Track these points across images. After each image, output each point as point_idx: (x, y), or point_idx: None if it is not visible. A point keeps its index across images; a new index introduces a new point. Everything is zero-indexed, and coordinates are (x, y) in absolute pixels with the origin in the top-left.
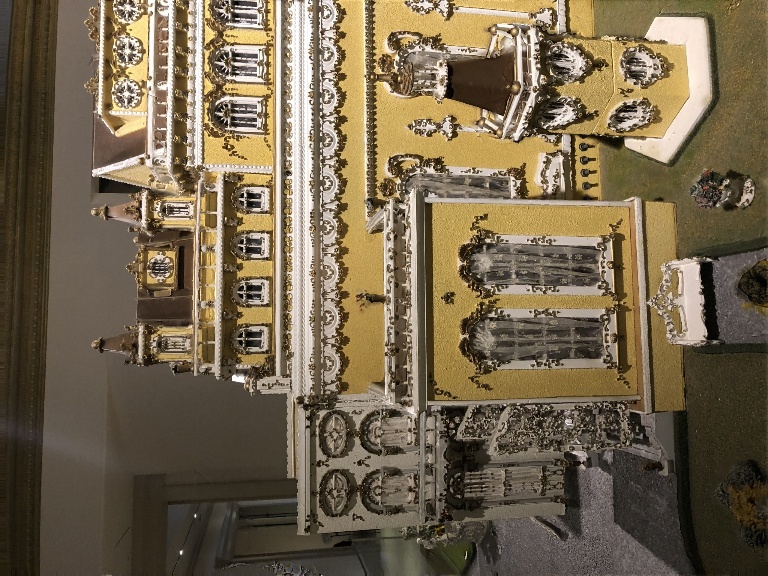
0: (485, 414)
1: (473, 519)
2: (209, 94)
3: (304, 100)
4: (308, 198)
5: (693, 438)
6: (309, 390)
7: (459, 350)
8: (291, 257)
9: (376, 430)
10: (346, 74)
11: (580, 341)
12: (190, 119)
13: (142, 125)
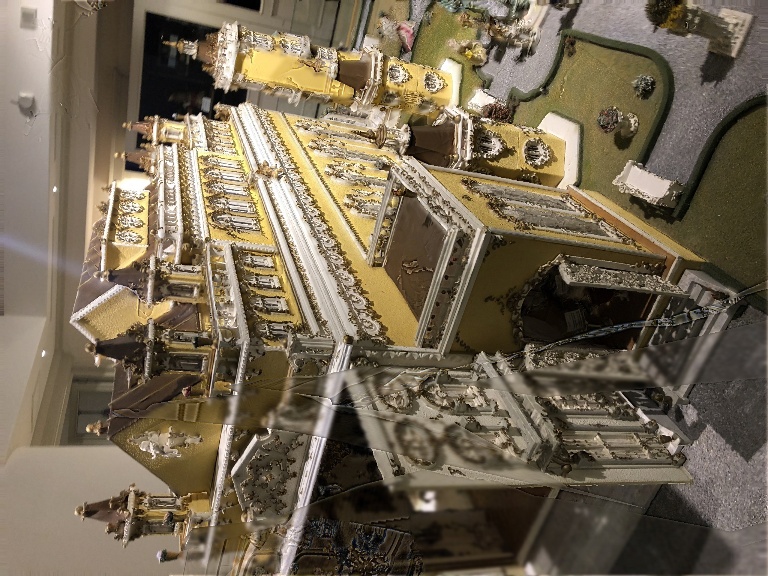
0: (544, 356)
1: (595, 479)
2: (211, 213)
3: (293, 209)
4: (312, 241)
5: (730, 266)
6: (355, 333)
7: (495, 217)
8: (305, 273)
9: (438, 393)
10: (321, 207)
11: None
12: (196, 221)
13: (141, 254)
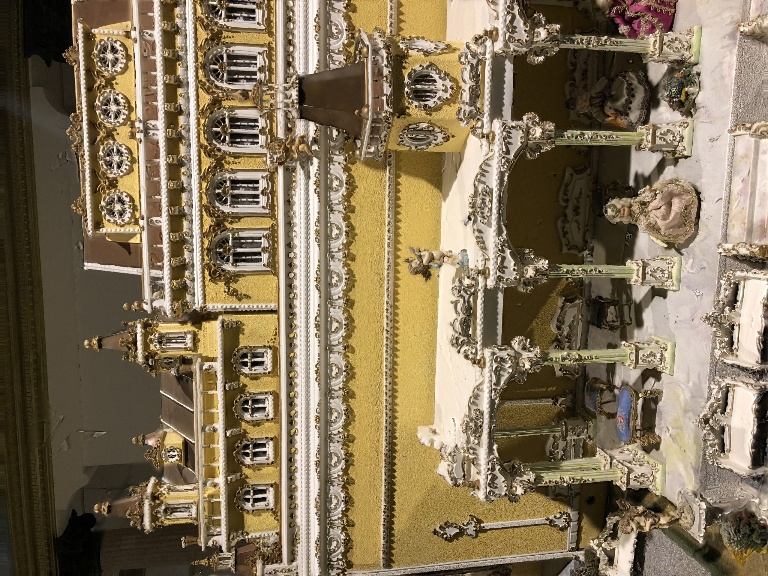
0: None
1: None
2: None
3: None
4: None
5: None
6: None
7: None
8: None
9: None
10: None
11: None
12: None
13: None
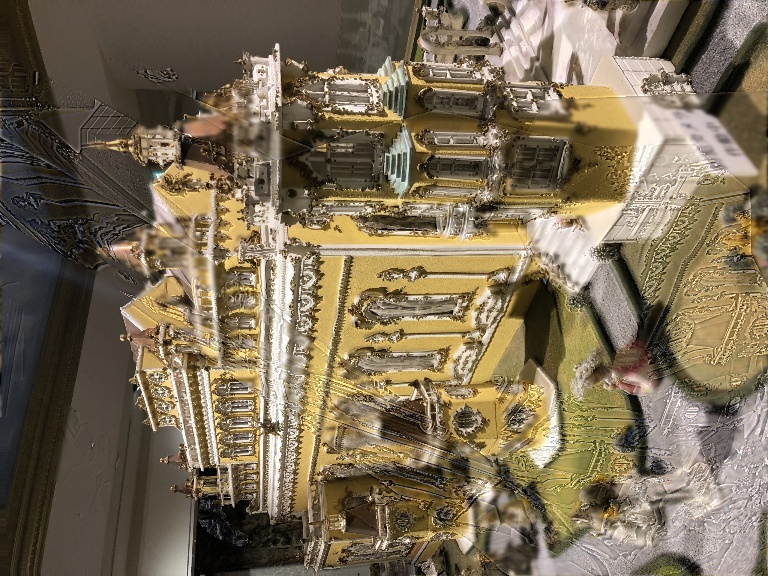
0: None
1: None
2: None
3: (276, 458)
4: None
5: (428, 567)
6: (275, 517)
7: None
8: (268, 488)
9: None
10: (302, 447)
11: (390, 554)
12: None
13: None
